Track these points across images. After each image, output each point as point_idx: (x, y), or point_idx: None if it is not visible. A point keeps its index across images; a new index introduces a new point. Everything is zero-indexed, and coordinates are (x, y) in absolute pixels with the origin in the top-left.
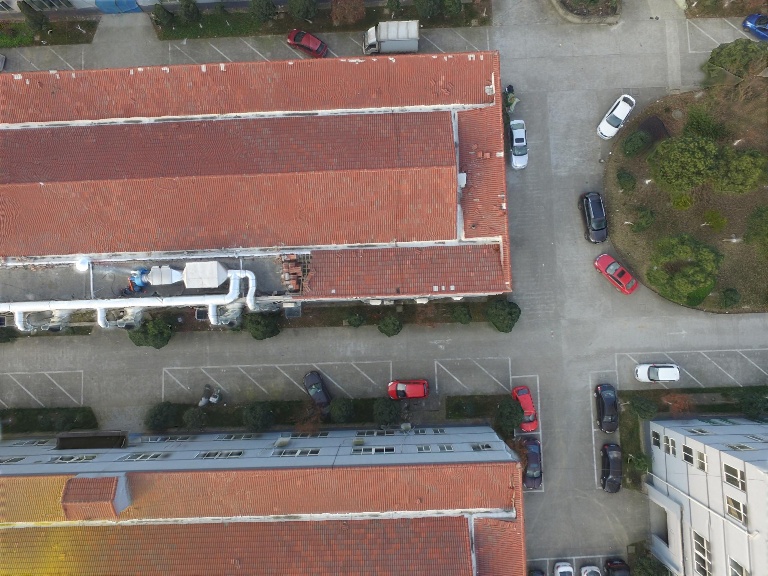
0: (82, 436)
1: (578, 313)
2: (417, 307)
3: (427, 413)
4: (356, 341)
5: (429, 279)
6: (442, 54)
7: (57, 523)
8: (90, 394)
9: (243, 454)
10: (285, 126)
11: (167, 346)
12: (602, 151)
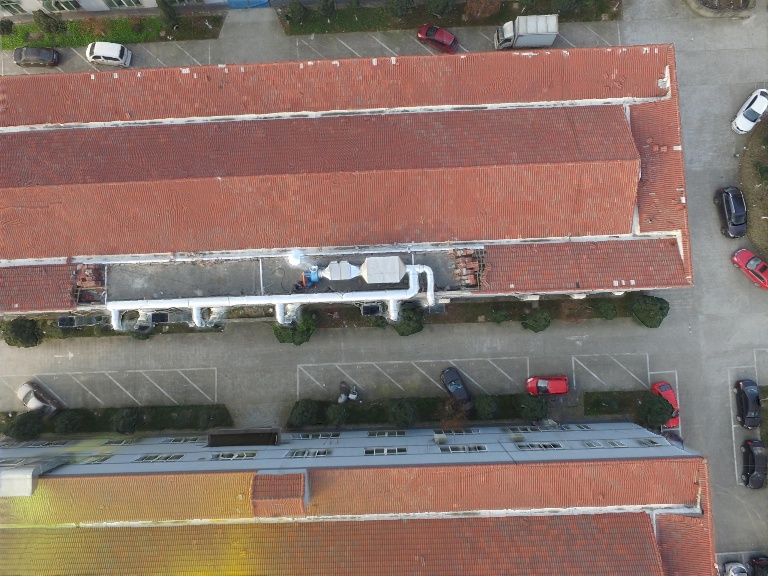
0: (234, 433)
1: (716, 308)
2: (553, 303)
3: (565, 409)
4: (492, 337)
5: (608, 274)
6: (617, 47)
7: (233, 520)
8: (224, 391)
9: (408, 450)
10: (457, 120)
11: None
12: (736, 146)
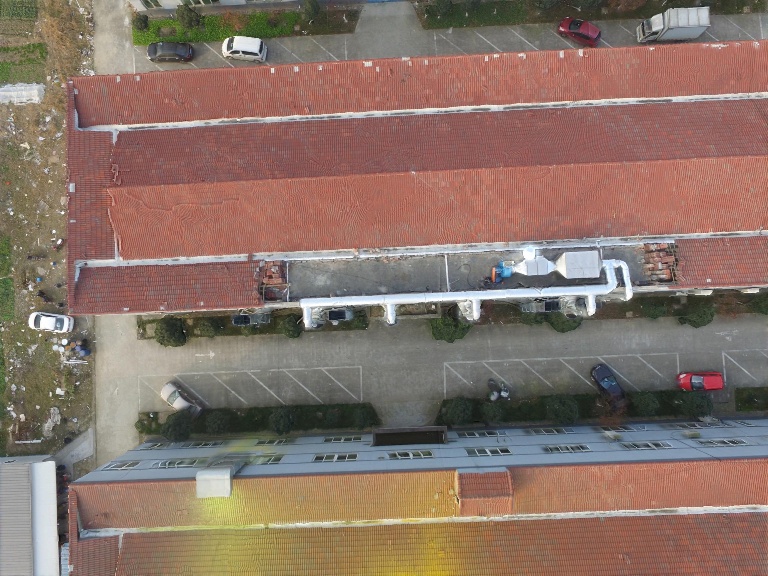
0: (400, 432)
1: None
2: (702, 298)
3: (716, 405)
4: (641, 333)
5: None
6: None
7: (425, 520)
8: (370, 390)
9: (590, 448)
10: (645, 113)
11: None
12: None
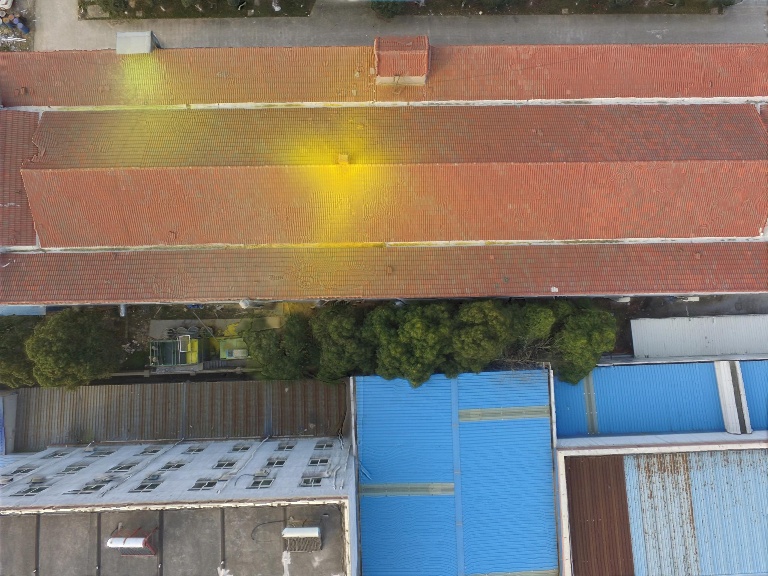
0: None
1: None
2: None
3: None
4: (576, 28)
5: None
6: None
7: (347, 104)
8: None
9: None
10: None
11: (387, 29)
12: None
